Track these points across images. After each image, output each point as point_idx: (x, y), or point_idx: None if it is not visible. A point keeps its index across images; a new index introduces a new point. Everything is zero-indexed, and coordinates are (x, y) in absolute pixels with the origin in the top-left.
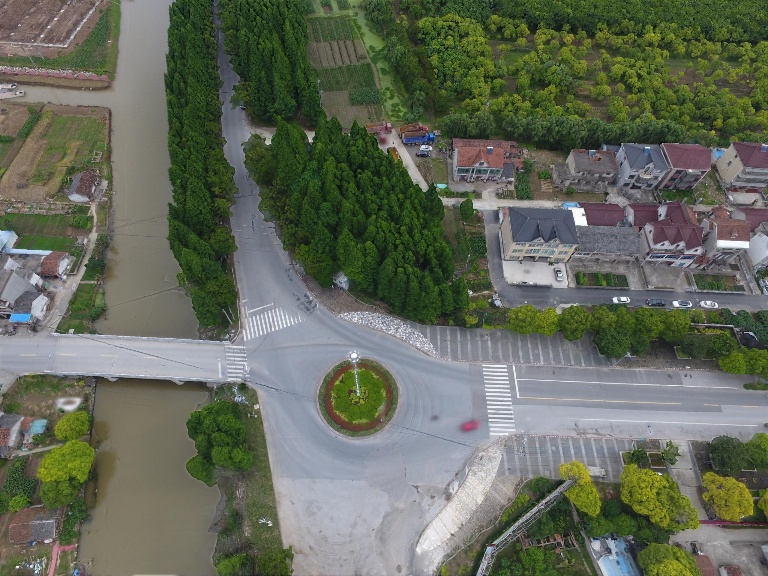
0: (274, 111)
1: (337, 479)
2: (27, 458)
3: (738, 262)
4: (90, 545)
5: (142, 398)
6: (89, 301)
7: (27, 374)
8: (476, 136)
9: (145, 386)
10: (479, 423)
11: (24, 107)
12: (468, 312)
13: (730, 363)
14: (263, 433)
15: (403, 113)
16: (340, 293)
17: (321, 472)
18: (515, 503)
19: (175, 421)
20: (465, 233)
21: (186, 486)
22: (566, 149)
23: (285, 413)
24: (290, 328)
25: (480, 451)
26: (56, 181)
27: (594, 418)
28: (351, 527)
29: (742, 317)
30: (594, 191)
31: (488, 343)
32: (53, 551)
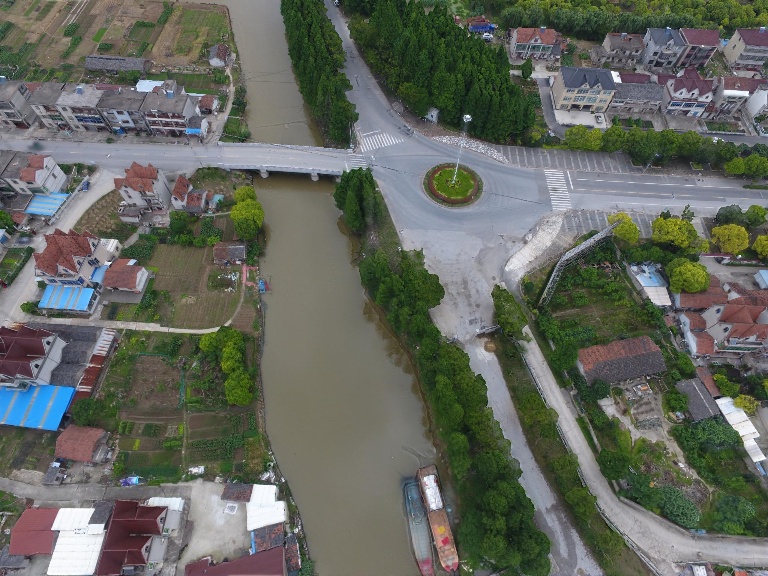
0: (368, 1)
1: (443, 230)
2: (213, 217)
3: (740, 115)
4: (266, 270)
5: (284, 195)
6: (237, 129)
7: (204, 167)
8: (528, 27)
9: (287, 184)
10: (544, 202)
11: (158, 3)
12: (534, 129)
13: (733, 164)
14: (385, 204)
15: (466, 13)
16: (431, 125)
17: (431, 226)
18: (574, 245)
19: (309, 212)
20: (524, 92)
21: (319, 256)
22: (602, 37)
23: (400, 193)
24: (396, 145)
25: (546, 218)
26: (195, 53)
27: (630, 202)
28: (457, 256)
29: (743, 148)
30: (625, 67)
31: (547, 157)
32: (243, 269)
